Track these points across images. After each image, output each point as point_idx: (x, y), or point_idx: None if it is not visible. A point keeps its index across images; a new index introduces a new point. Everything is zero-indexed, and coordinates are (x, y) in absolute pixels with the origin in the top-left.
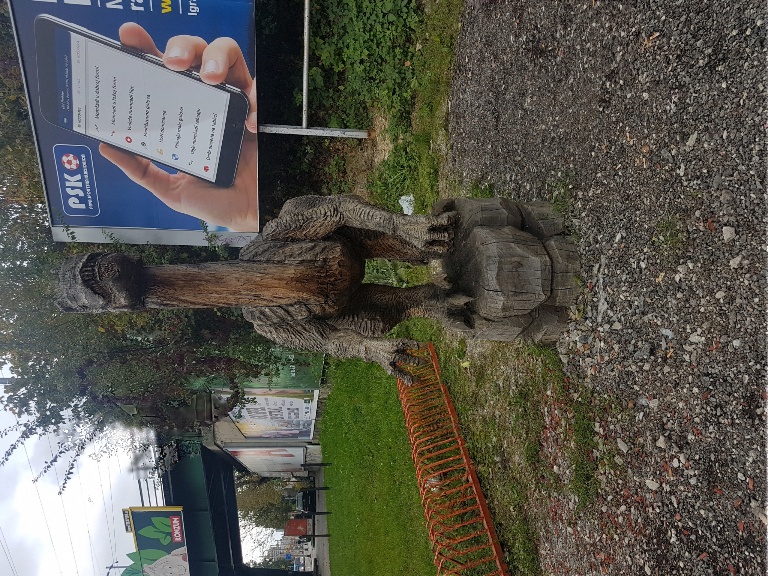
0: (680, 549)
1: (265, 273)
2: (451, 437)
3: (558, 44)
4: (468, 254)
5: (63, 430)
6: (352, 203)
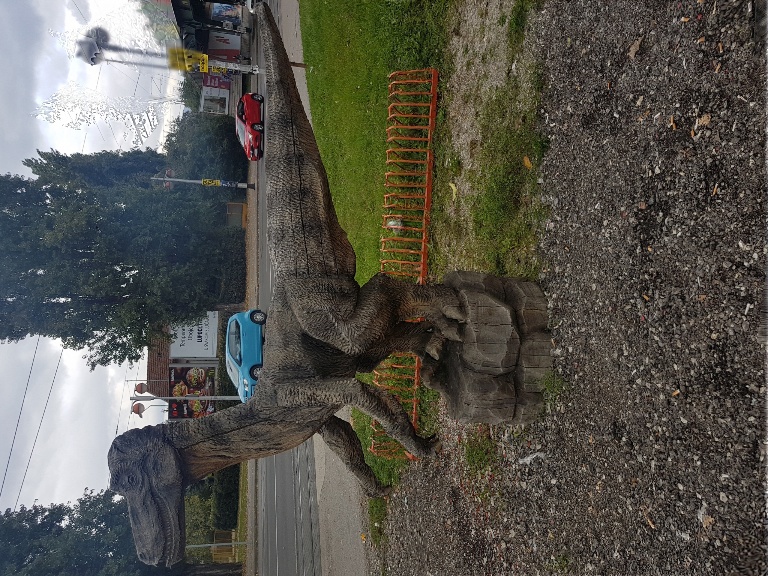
0: (484, 568)
1: (280, 448)
2: (419, 227)
3: (650, 299)
4: (456, 374)
5: (33, 108)
6: (362, 408)
